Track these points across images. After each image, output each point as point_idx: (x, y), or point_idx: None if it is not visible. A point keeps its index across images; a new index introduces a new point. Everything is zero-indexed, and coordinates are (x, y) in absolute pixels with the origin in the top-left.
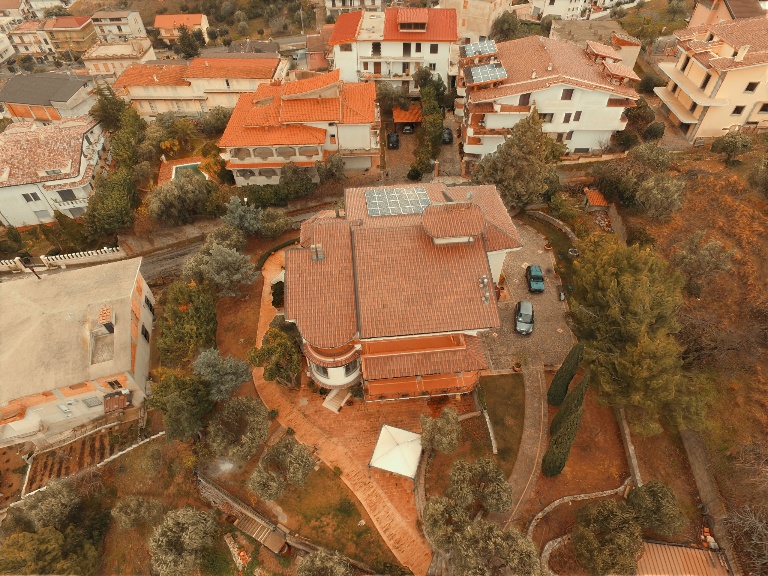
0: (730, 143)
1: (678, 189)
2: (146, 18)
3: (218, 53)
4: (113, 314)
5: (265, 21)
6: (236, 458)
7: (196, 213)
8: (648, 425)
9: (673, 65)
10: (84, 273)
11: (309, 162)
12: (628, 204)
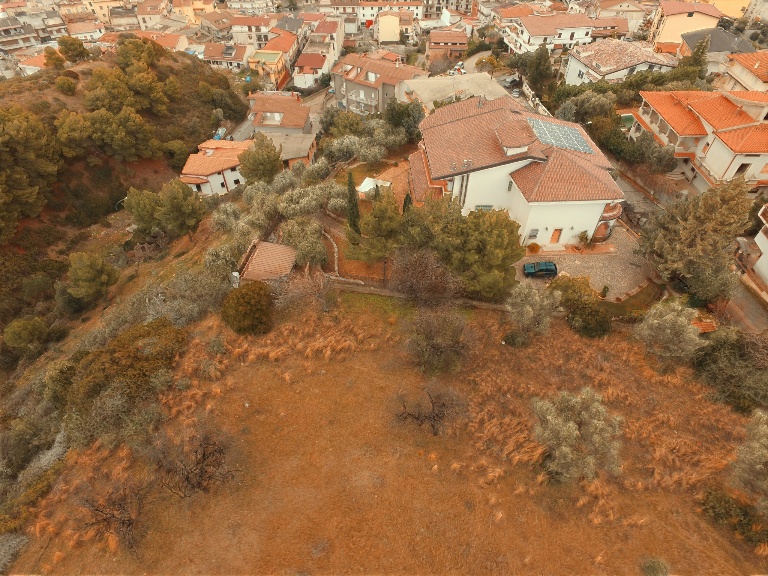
0: None
1: None
2: None
3: None
4: (463, 95)
5: None
6: None
7: None
8: None
9: None
10: (498, 88)
11: None
12: None
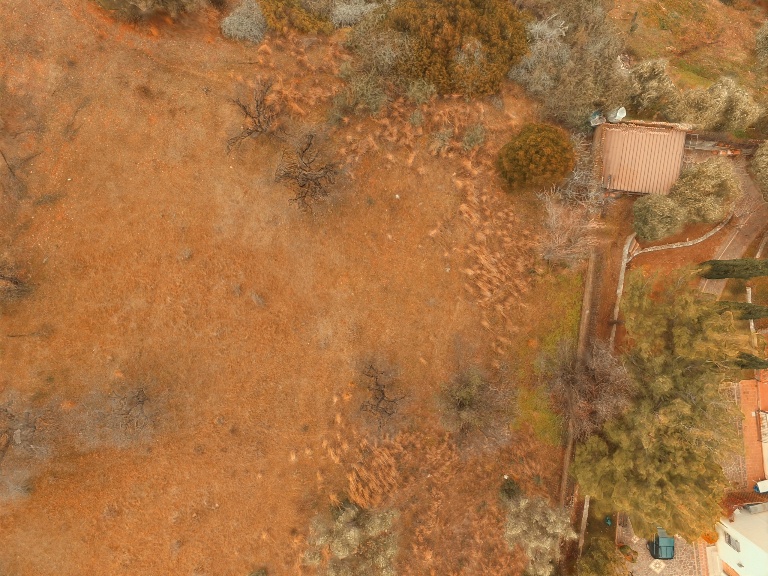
0: None
1: None
2: None
3: None
4: None
5: None
6: None
7: None
8: None
9: None
10: None
11: None
12: None
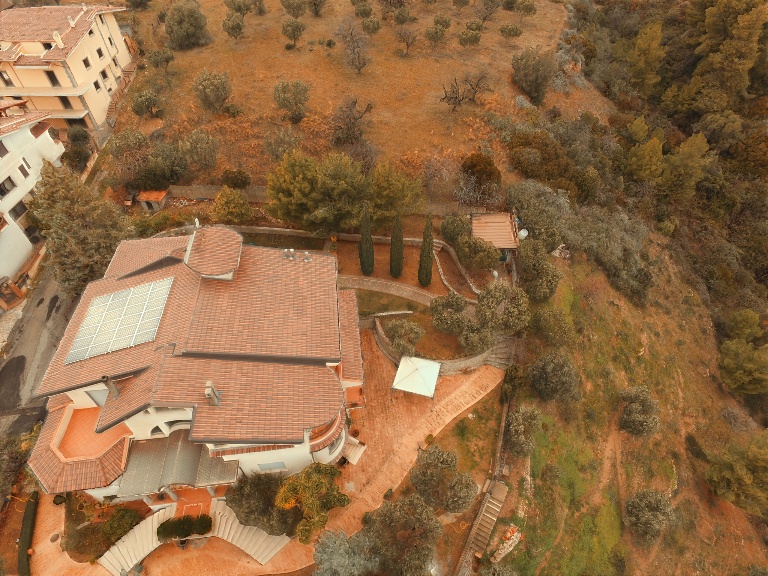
0: (147, 100)
1: None
2: None
3: None
4: None
5: None
6: None
7: None
8: (418, 206)
9: None
10: None
11: None
12: (177, 178)
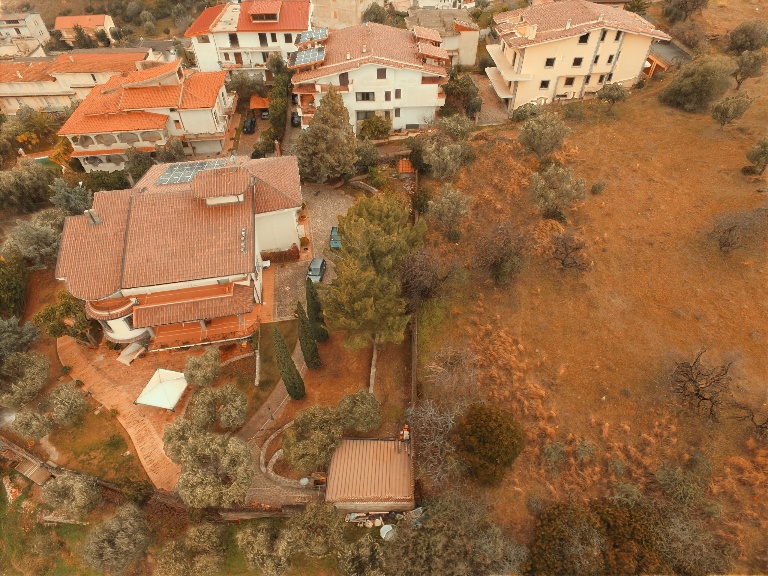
0: (521, 112)
1: (456, 152)
2: (49, 20)
3: (88, 49)
4: None
5: (173, 21)
6: (6, 405)
7: (42, 201)
8: None
9: (498, 47)
10: None
11: (154, 147)
12: (429, 169)
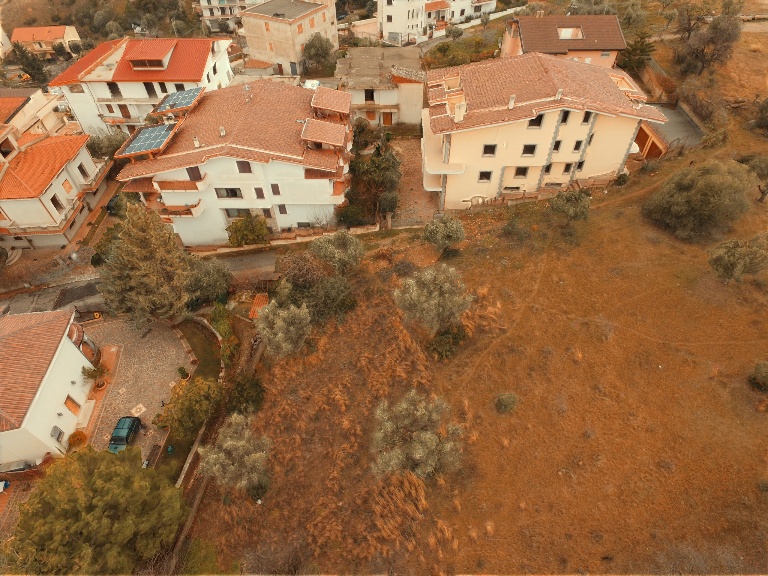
0: (432, 233)
1: (301, 318)
2: None
3: None
4: None
5: None
6: None
7: None
8: None
9: None
10: None
11: None
12: None
